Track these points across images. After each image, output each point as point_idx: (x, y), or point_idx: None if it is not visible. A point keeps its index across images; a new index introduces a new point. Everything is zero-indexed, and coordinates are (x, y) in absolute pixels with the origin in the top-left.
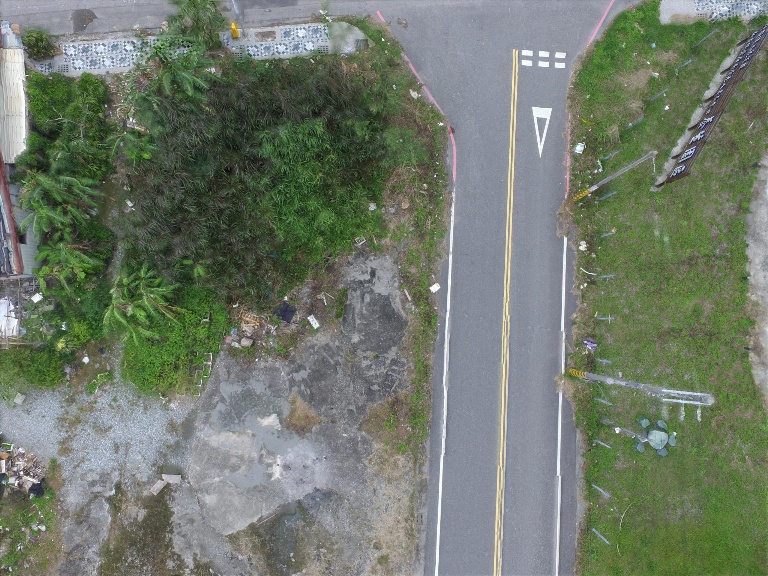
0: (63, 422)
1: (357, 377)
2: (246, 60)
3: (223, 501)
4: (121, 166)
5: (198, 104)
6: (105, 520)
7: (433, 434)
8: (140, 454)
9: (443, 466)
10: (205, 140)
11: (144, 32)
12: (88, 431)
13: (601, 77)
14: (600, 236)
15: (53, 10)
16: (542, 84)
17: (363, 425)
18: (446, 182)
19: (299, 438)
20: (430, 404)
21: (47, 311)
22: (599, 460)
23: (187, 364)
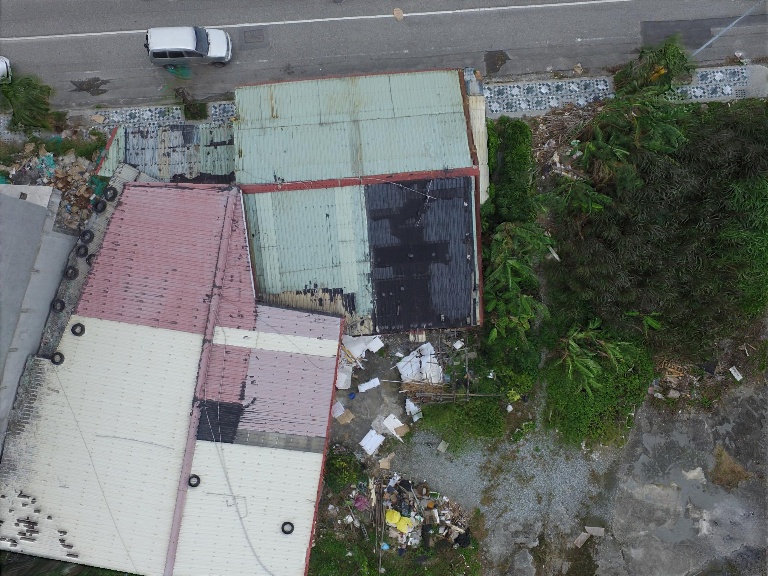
0: (485, 471)
1: None
2: (663, 104)
3: (649, 556)
4: None
5: (660, 154)
6: (530, 572)
7: None
8: (563, 505)
9: None
10: (678, 192)
11: (557, 74)
12: (510, 481)
13: None
14: None
15: (466, 51)
16: None
17: None
18: None
19: (725, 493)
20: None
21: (470, 358)
22: None
23: (614, 415)
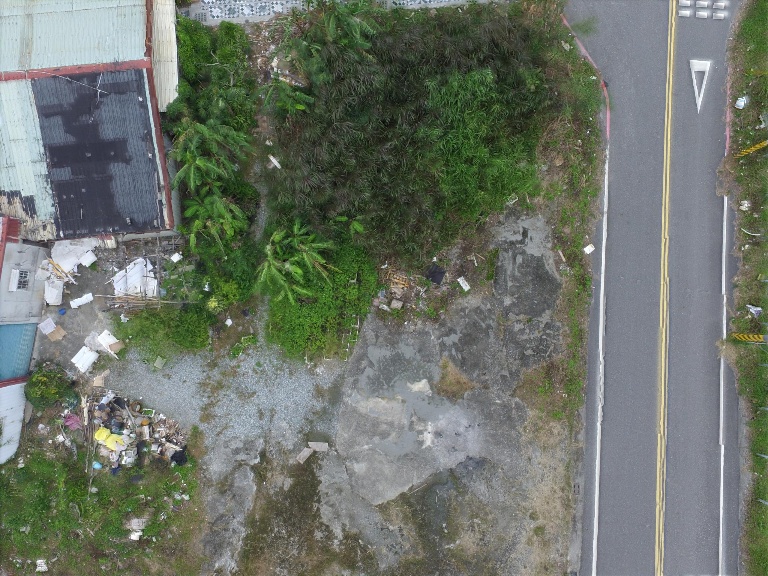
0: (205, 387)
1: (510, 341)
2: (391, 9)
3: (372, 470)
4: (262, 120)
5: (358, 50)
6: (250, 489)
7: (589, 401)
8: (285, 421)
9: (601, 434)
10: (369, 87)
11: None
12: (231, 397)
13: (762, 28)
14: (764, 195)
15: None
16: (700, 36)
17: (517, 391)
18: (600, 138)
19: (450, 405)
20: (585, 370)
21: (188, 271)
22: (764, 428)
23: (335, 327)
